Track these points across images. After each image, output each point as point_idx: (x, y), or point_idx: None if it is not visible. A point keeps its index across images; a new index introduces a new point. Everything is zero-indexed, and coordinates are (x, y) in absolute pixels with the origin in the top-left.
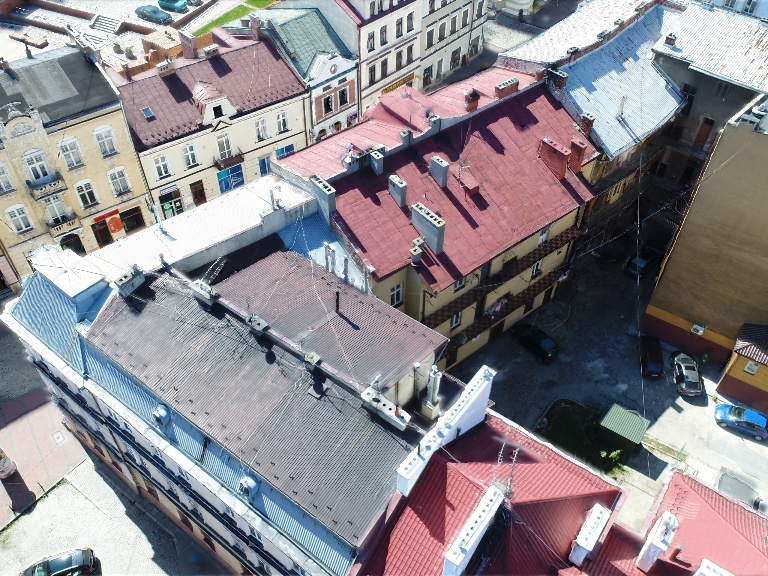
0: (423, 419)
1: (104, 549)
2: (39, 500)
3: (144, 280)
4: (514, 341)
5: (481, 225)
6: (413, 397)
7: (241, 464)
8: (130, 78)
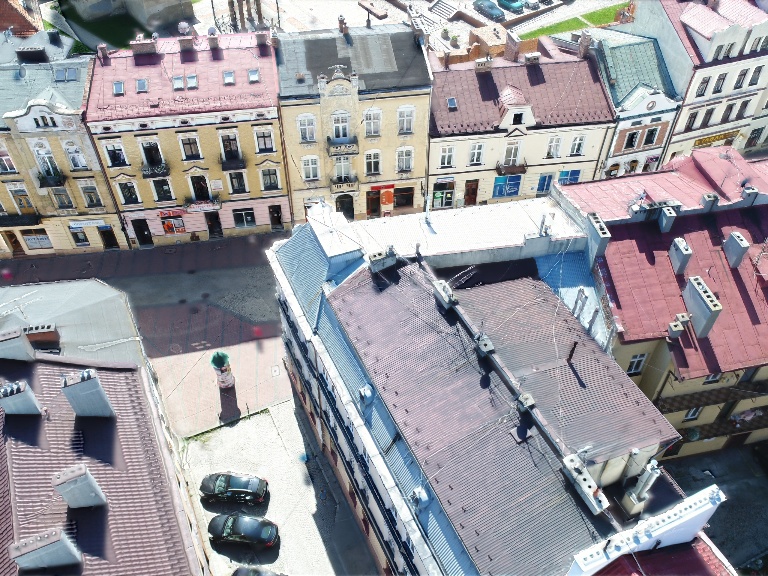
0: (621, 509)
1: (277, 486)
2: (242, 419)
3: (395, 263)
4: (753, 459)
5: (763, 323)
6: (618, 481)
7: (421, 474)
8: (447, 66)
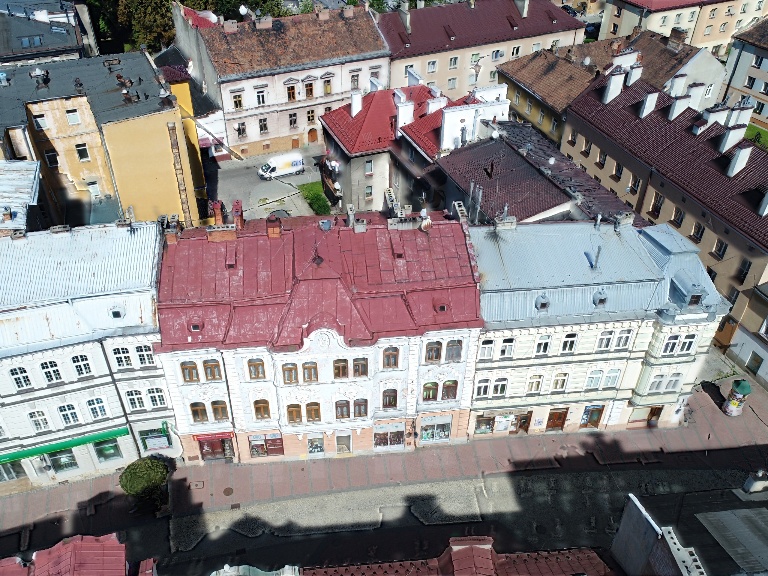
0: None
1: None
2: None
3: None
4: None
5: None
6: None
7: None
8: None
